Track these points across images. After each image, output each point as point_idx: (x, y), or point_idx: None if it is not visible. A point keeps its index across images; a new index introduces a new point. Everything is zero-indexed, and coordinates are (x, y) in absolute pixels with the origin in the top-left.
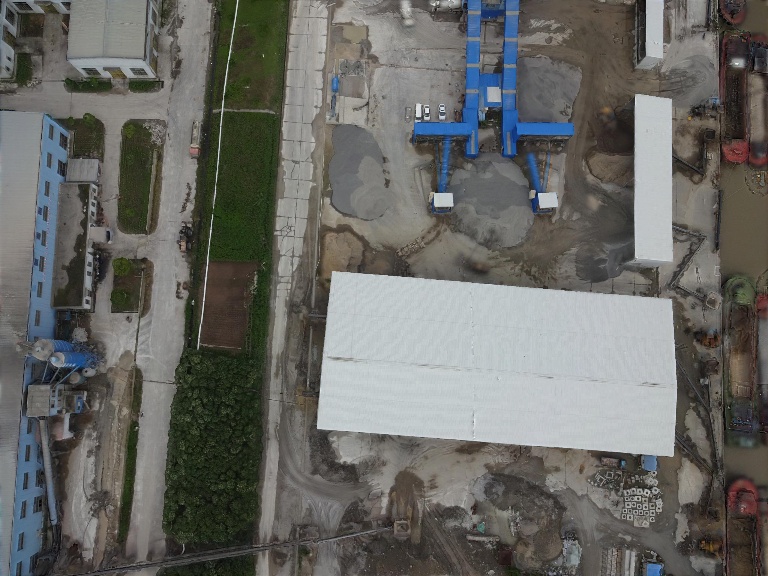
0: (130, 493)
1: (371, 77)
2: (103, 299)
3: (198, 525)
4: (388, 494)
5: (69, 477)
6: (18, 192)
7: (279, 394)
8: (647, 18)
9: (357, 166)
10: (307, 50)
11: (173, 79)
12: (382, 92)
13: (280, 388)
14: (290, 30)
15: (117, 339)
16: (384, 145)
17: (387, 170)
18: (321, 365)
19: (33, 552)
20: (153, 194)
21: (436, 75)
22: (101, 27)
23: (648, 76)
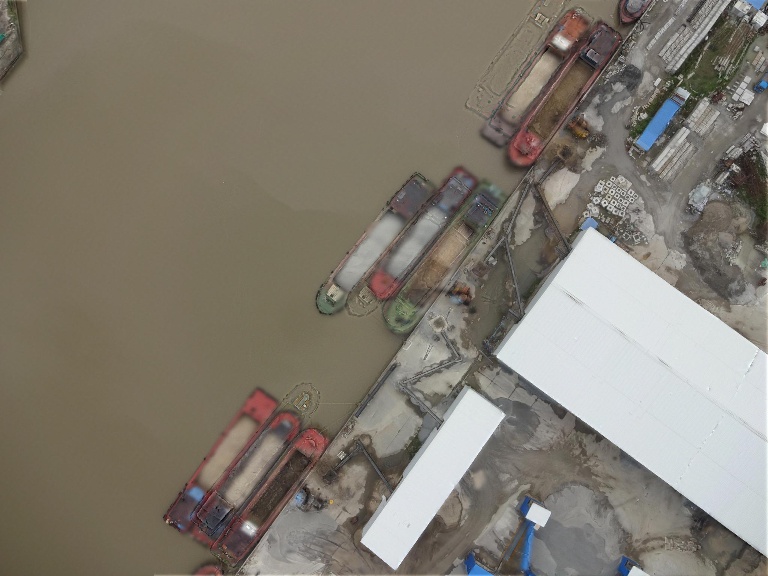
0: None
1: None
2: None
3: None
4: None
5: None
6: None
7: None
8: None
9: None
10: None
11: None
12: None
13: None
14: None
15: None
16: None
17: None
18: None
19: None
20: None
21: None
22: None
23: (340, 569)
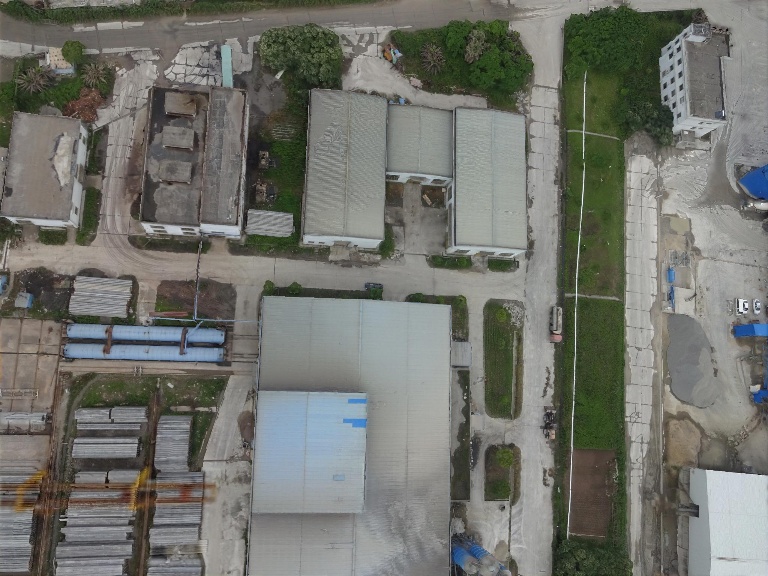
0: None
1: (696, 269)
2: (476, 487)
3: None
4: None
5: None
6: (433, 390)
7: None
8: None
9: (697, 358)
10: (642, 239)
11: (527, 260)
12: (706, 284)
13: (640, 575)
14: (626, 218)
15: (491, 529)
16: (711, 335)
17: (715, 360)
18: (703, 563)
19: None
20: (516, 377)
21: (748, 270)
22: (489, 215)
23: None
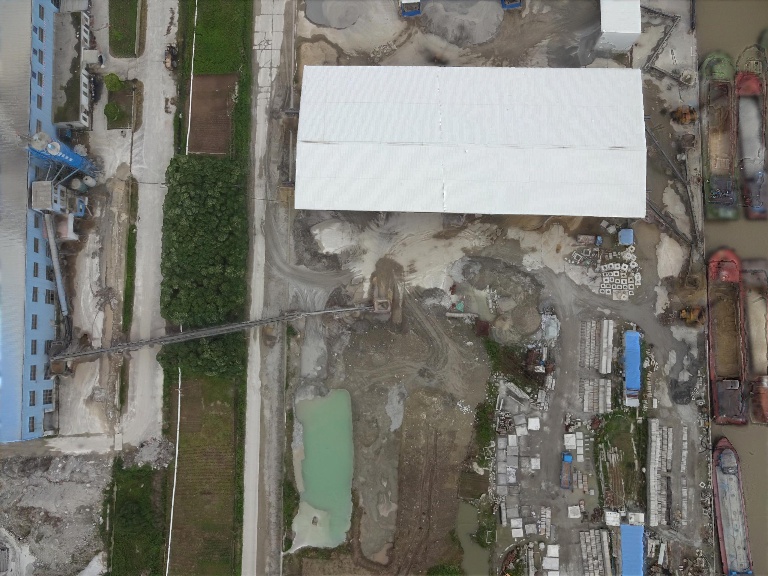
0: (131, 288)
1: None
2: (99, 118)
3: (191, 306)
4: (369, 279)
5: (77, 276)
6: (14, 12)
7: (263, 193)
8: None
9: None
10: None
11: None
12: None
13: (264, 188)
14: None
15: (114, 153)
16: None
17: None
18: None
19: (48, 338)
20: (140, 21)
21: None
22: None
23: None
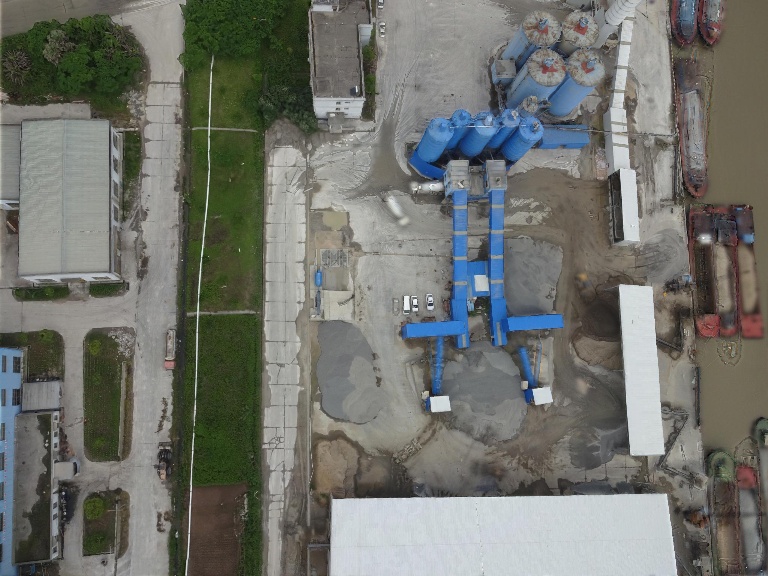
0: None
1: (355, 267)
2: (72, 541)
3: None
4: None
5: None
6: None
7: None
8: (623, 201)
9: (348, 369)
10: (286, 240)
11: (140, 280)
12: (367, 283)
13: None
14: (266, 219)
15: None
16: (373, 340)
17: (378, 367)
18: None
19: None
20: (124, 413)
21: (421, 262)
22: (58, 238)
23: (624, 252)
